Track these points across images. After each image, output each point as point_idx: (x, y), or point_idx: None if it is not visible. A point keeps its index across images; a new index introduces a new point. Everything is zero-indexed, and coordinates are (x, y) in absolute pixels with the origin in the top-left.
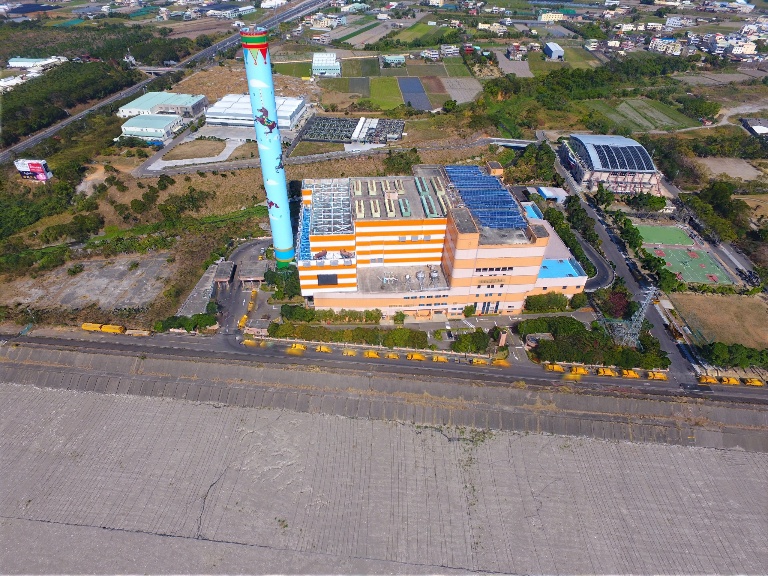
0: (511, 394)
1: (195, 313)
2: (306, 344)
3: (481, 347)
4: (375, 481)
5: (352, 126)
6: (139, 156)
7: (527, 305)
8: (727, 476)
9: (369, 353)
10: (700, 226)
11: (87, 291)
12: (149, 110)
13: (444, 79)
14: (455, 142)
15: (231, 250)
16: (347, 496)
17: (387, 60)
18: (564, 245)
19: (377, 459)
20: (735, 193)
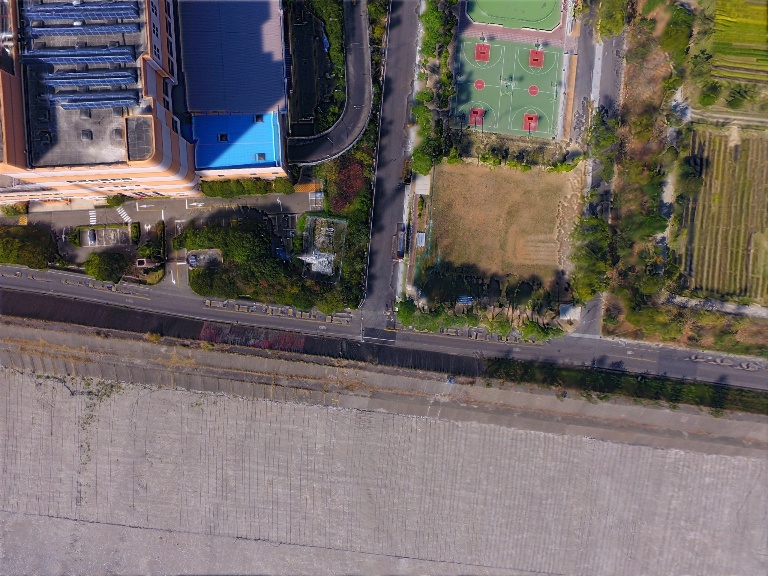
0: (143, 348)
1: None
2: None
3: None
4: None
5: None
6: None
7: (203, 192)
8: (350, 440)
9: None
10: None
11: None
12: None
13: None
14: None
15: None
16: None
17: None
18: (282, 68)
19: None
20: None
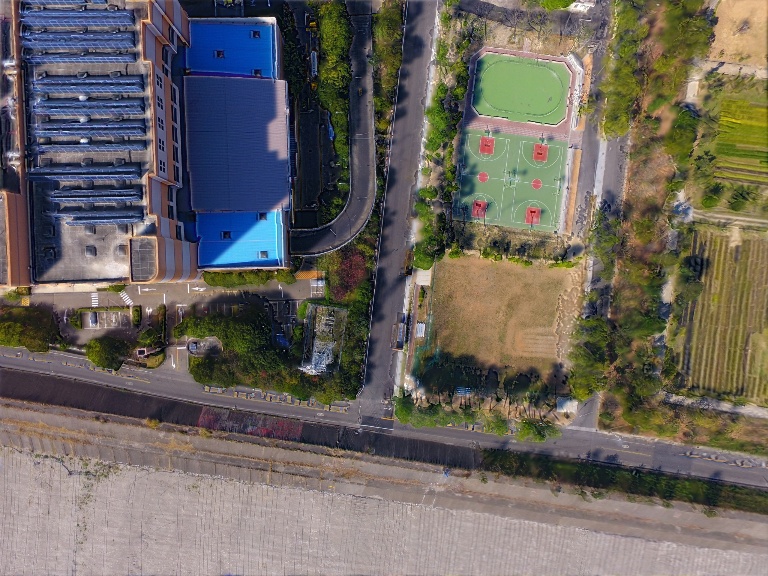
0: (141, 432)
1: None
2: None
3: None
4: None
5: None
6: None
7: (205, 281)
8: (345, 526)
9: None
10: None
11: None
12: None
13: None
14: None
15: None
16: None
17: None
18: (287, 167)
19: None
20: None
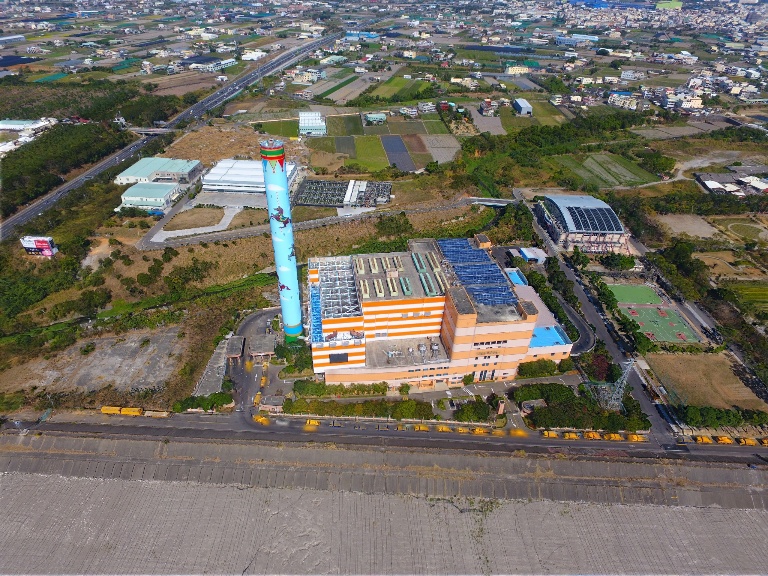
0: (513, 463)
1: (211, 392)
2: (319, 419)
3: (482, 417)
4: (397, 557)
5: (343, 190)
6: (141, 227)
7: (520, 372)
8: (708, 534)
9: (379, 426)
10: (666, 284)
11: (102, 371)
12: (146, 178)
13: (424, 137)
14: (440, 203)
15: (238, 322)
16: (372, 574)
17: (369, 118)
18: (549, 311)
19: (396, 535)
20: (695, 251)
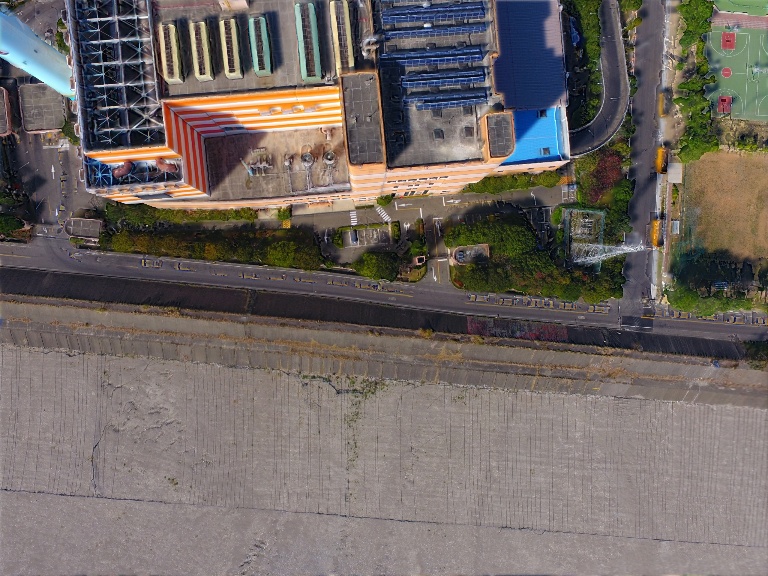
0: (413, 344)
1: None
2: None
3: (387, 279)
4: (258, 439)
5: None
6: None
7: None
8: (609, 427)
9: (244, 275)
10: None
11: None
12: None
13: None
14: None
15: None
16: (231, 455)
17: None
18: (563, 63)
19: (260, 416)
20: None
